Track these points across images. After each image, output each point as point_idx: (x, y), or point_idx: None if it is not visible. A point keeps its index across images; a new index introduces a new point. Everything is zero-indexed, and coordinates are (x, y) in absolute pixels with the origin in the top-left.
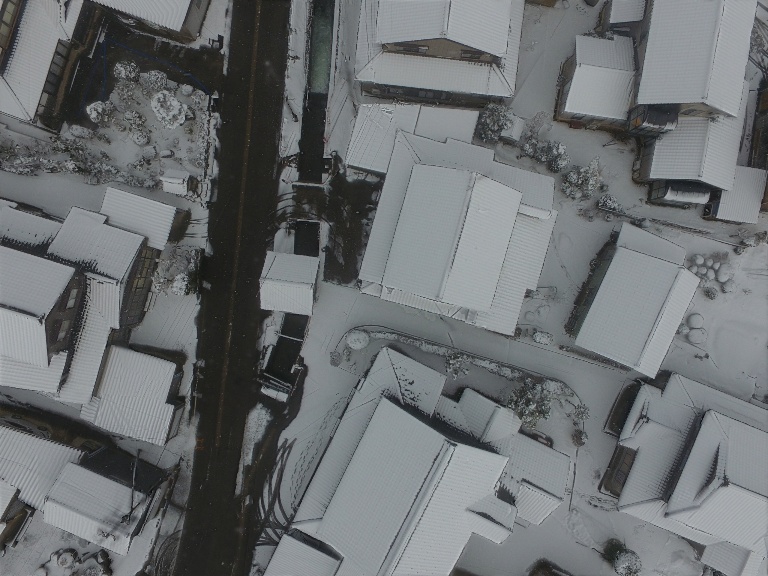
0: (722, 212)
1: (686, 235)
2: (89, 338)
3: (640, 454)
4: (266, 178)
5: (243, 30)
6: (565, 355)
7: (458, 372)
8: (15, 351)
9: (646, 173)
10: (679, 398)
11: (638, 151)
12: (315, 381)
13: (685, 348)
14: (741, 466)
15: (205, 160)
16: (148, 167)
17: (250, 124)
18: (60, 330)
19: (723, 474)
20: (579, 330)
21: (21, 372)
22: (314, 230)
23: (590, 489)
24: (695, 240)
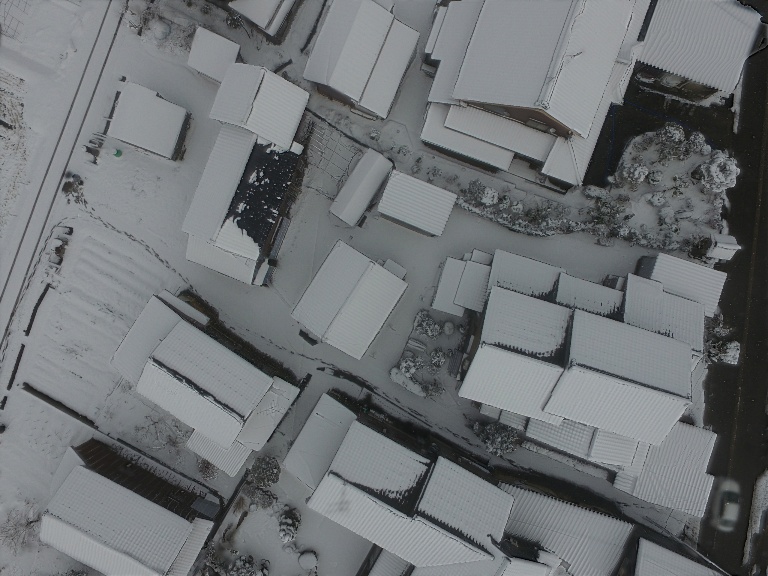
0: None
1: None
2: None
3: None
4: None
5: (754, 87)
6: None
7: None
8: (631, 429)
9: None
10: None
11: None
12: None
13: None
14: None
15: None
16: (661, 228)
17: (761, 183)
18: None
19: None
20: None
21: (612, 447)
22: None
23: None
24: None
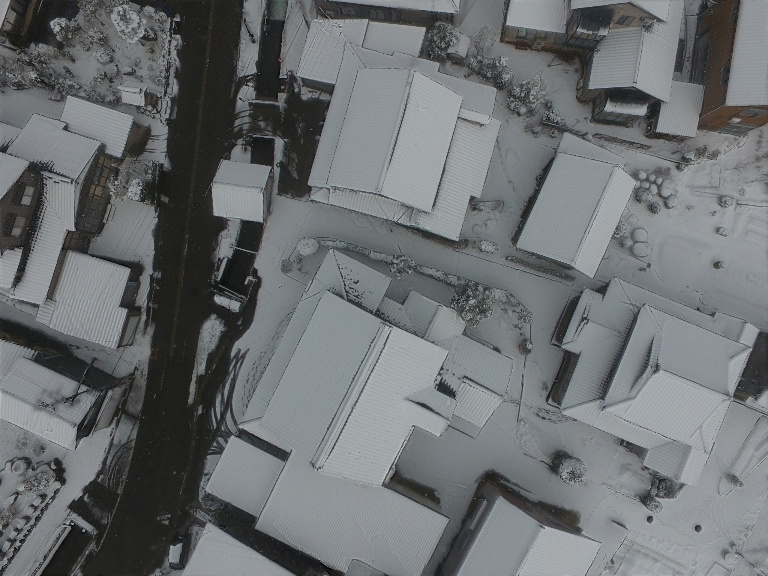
0: (661, 126)
1: (629, 152)
2: (45, 238)
3: (582, 357)
4: (224, 96)
5: None
6: (512, 268)
7: (402, 273)
8: None
9: (588, 89)
10: (619, 300)
11: (582, 71)
12: (268, 292)
13: (630, 261)
14: (674, 356)
15: (165, 78)
16: (110, 84)
17: (209, 45)
18: (15, 224)
19: (656, 362)
20: (520, 233)
21: None
22: (270, 147)
23: (538, 401)
24: (638, 157)
